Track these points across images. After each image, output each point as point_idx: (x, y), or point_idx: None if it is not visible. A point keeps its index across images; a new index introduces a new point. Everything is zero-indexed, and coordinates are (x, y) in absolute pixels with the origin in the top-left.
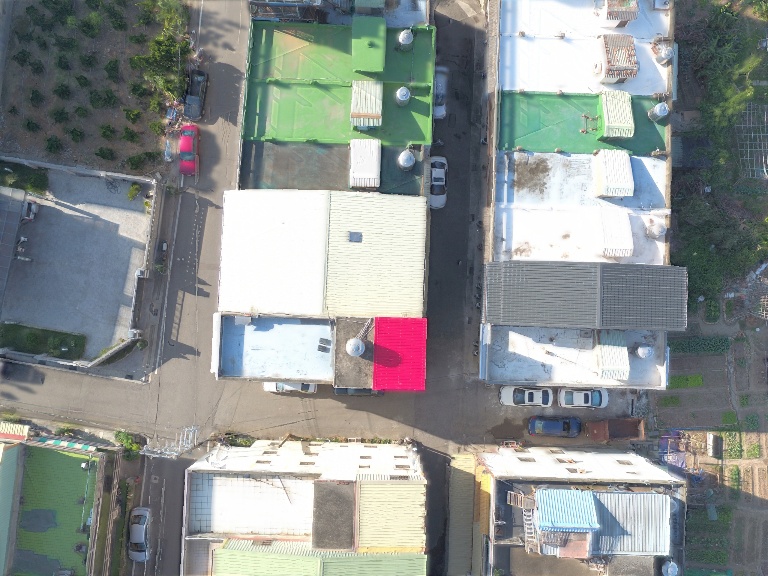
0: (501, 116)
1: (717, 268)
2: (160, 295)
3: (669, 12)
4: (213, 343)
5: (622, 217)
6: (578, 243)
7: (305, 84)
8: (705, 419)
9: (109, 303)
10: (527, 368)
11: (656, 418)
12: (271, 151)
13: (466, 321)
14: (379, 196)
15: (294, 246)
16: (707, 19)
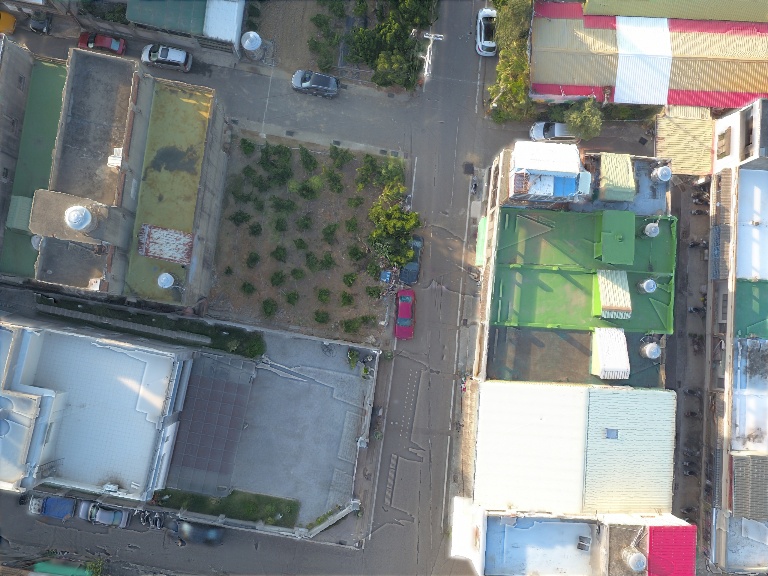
0: (734, 303)
1: None
2: (373, 459)
3: None
4: (454, 527)
5: None
6: None
7: (548, 270)
8: None
9: (323, 467)
10: (760, 553)
11: None
12: (514, 336)
13: None
14: (633, 392)
15: (552, 442)
16: None
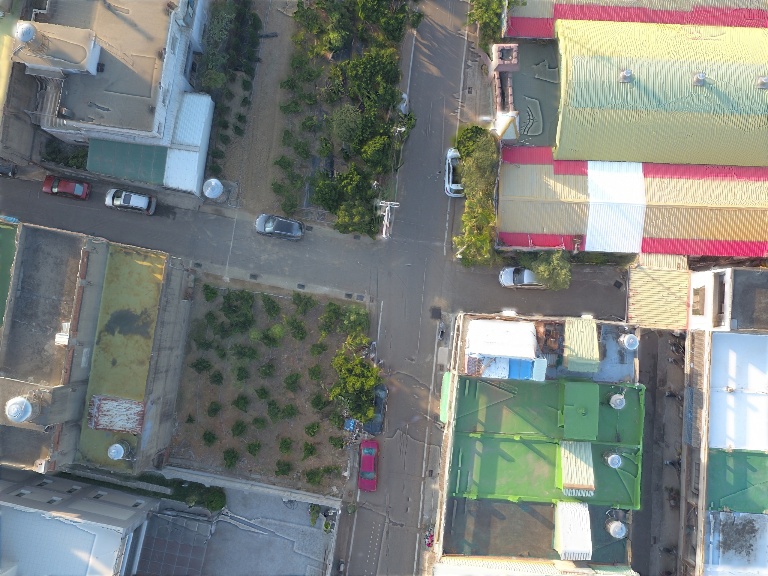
0: (707, 474)
1: None
2: None
3: None
4: None
5: None
6: None
7: (509, 439)
8: None
9: None
10: None
11: None
12: (473, 507)
13: None
14: None
15: None
16: None
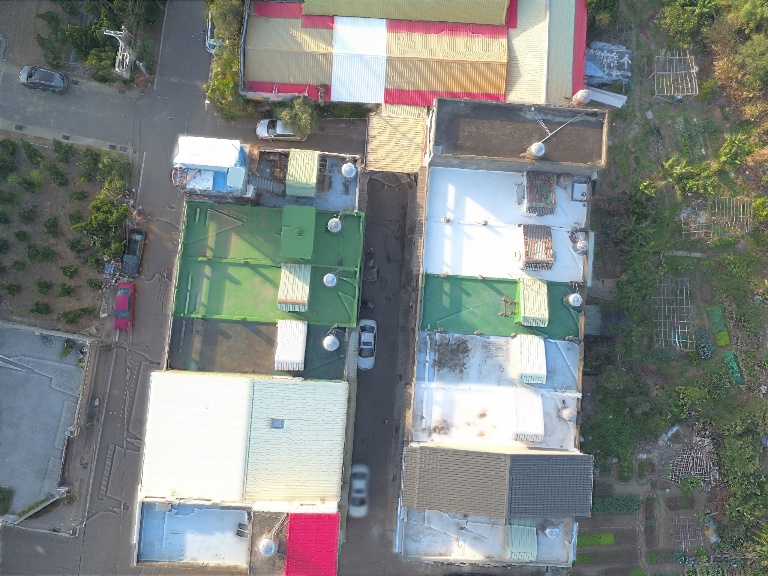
0: (424, 298)
1: (631, 431)
2: (91, 448)
3: (586, 203)
4: (137, 514)
5: (535, 401)
6: (494, 422)
7: (236, 263)
8: (616, 575)
9: (39, 456)
10: (442, 543)
11: (570, 574)
12: (201, 327)
13: (391, 479)
14: (302, 383)
15: (217, 431)
16: (628, 192)
